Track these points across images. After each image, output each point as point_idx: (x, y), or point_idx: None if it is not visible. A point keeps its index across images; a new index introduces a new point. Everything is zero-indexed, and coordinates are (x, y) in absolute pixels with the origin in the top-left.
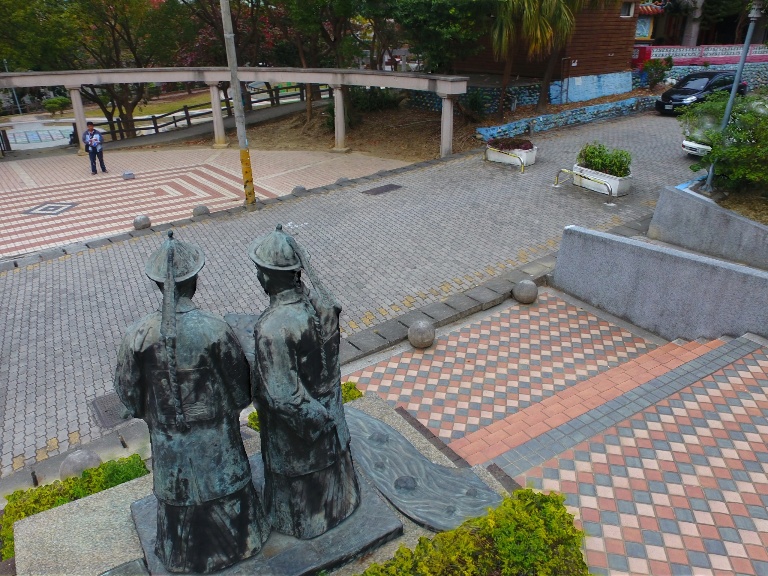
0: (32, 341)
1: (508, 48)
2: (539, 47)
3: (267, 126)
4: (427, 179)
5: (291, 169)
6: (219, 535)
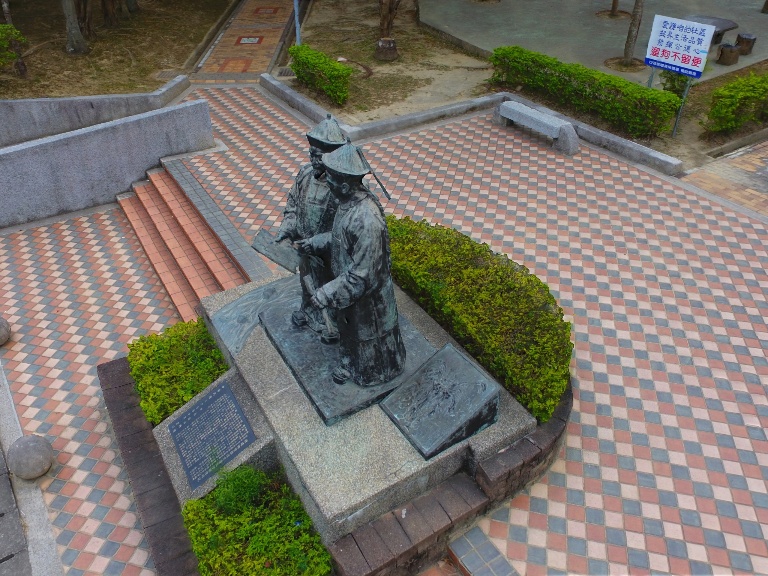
0: None
1: None
2: None
3: None
4: None
5: None
6: None
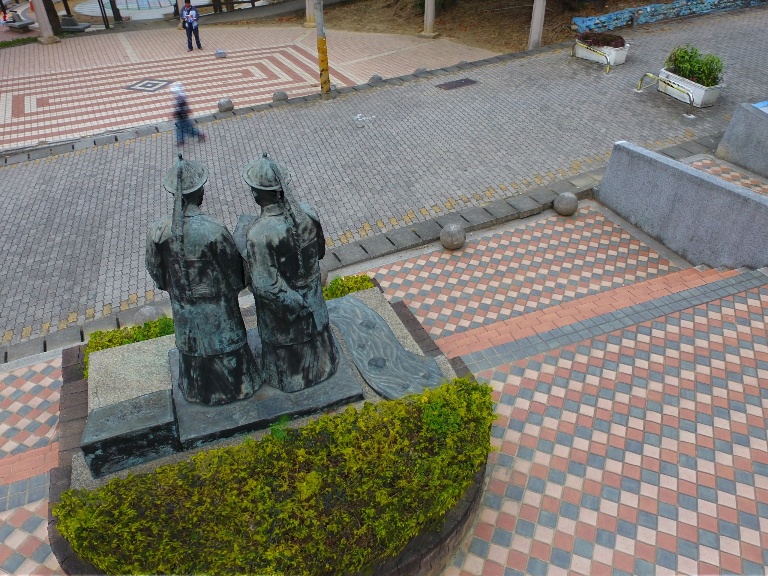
0: (124, 210)
1: None
2: None
3: (359, 4)
4: (505, 75)
5: (375, 54)
6: (220, 380)
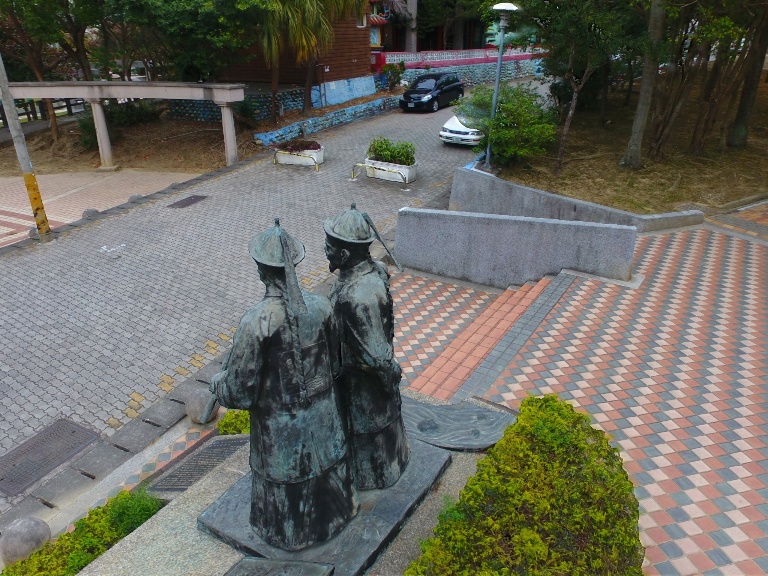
0: None
1: (279, 55)
2: (307, 54)
3: (4, 150)
4: (229, 187)
5: (61, 194)
6: (336, 500)
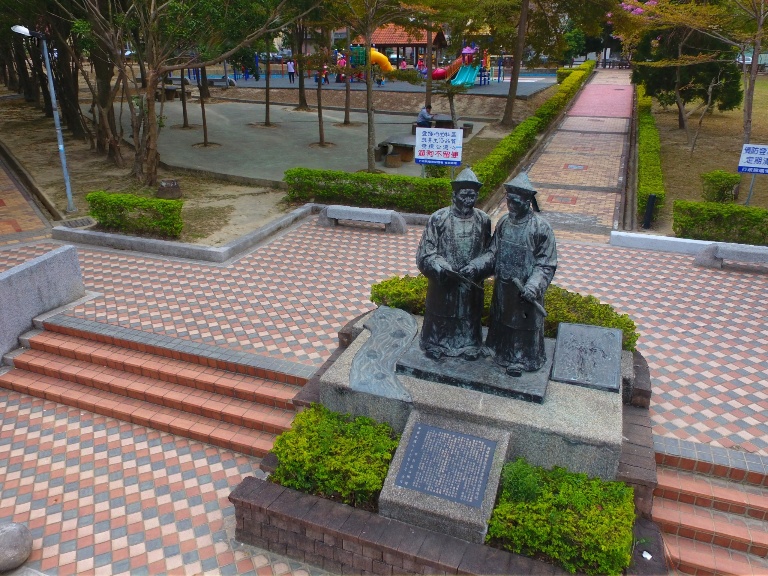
0: None
1: None
2: None
3: None
4: None
5: None
6: None
